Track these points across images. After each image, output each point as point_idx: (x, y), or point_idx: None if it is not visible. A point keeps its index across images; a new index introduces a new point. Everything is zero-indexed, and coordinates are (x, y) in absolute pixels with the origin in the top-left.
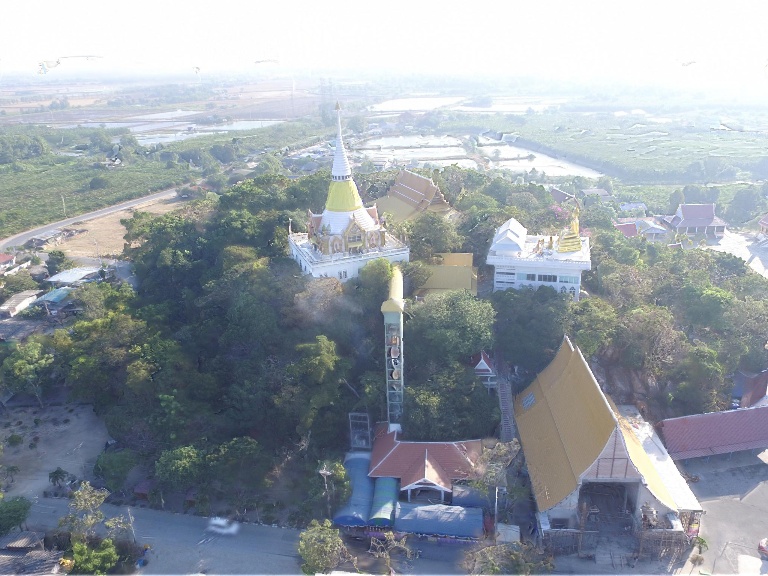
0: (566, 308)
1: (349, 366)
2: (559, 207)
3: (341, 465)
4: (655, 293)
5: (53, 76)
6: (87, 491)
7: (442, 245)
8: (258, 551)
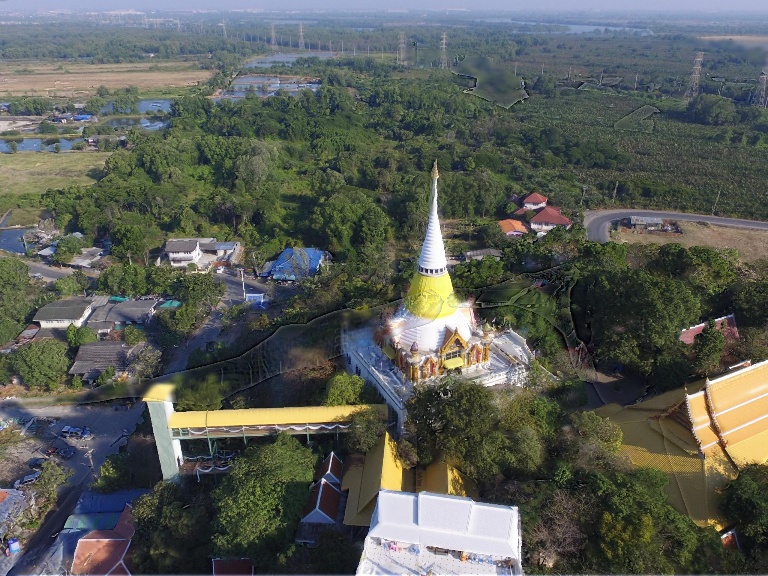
0: None
1: None
2: None
3: (113, 468)
4: None
5: None
6: (158, 354)
7: (437, 441)
8: (100, 461)
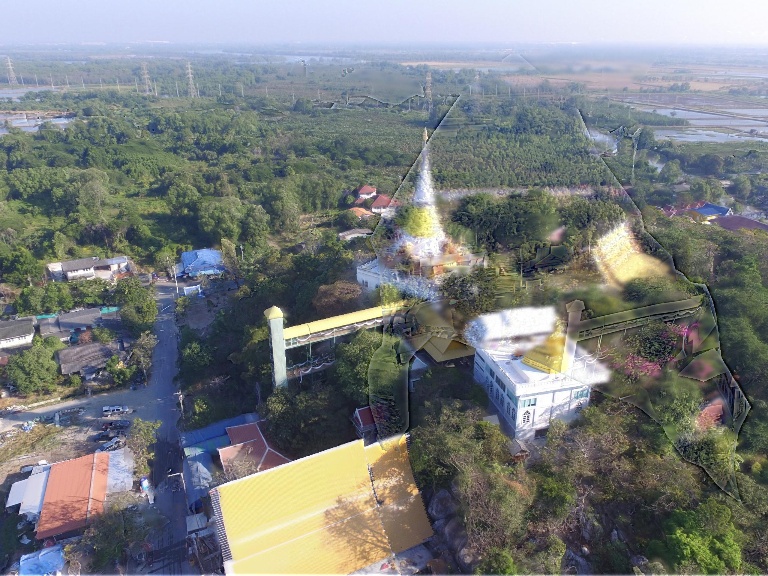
0: (442, 413)
1: (259, 345)
2: (739, 337)
3: (205, 404)
4: (649, 494)
5: (349, 79)
6: (153, 337)
7: None
8: None
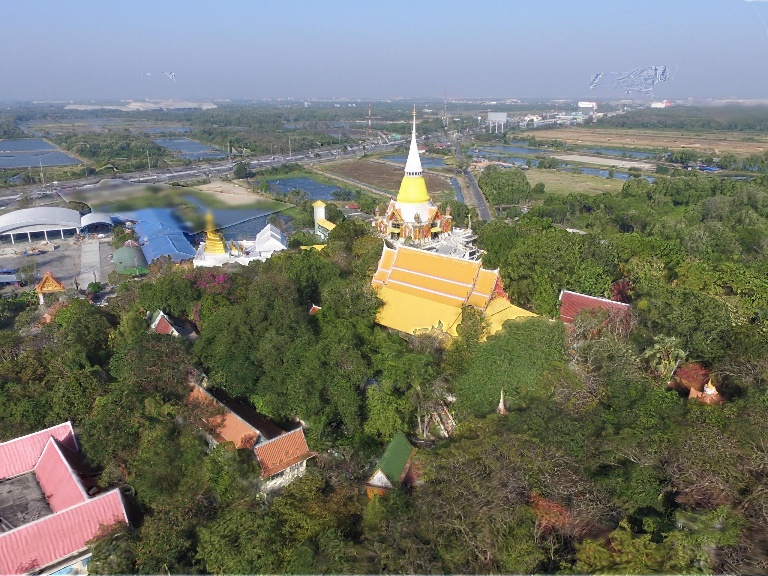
0: None
1: None
2: None
3: None
4: None
5: None
6: None
7: None
8: None
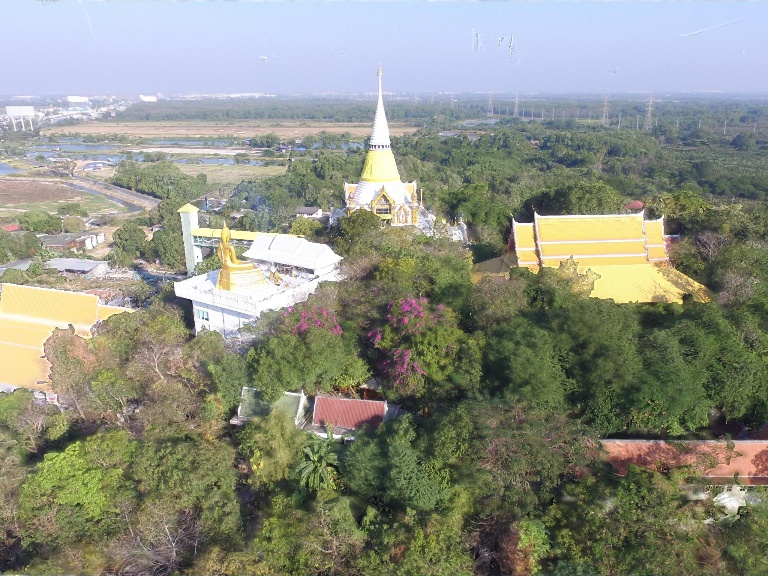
0: None
1: None
2: (510, 350)
3: None
4: None
5: None
6: None
7: None
8: None
